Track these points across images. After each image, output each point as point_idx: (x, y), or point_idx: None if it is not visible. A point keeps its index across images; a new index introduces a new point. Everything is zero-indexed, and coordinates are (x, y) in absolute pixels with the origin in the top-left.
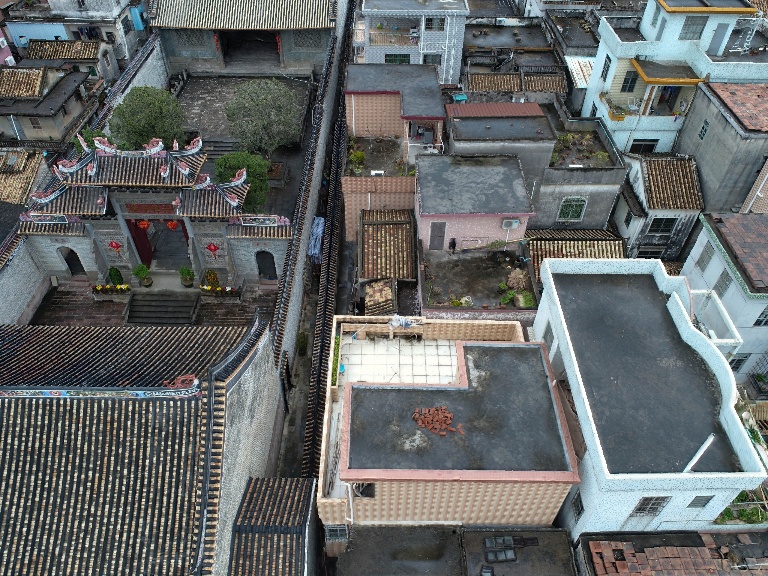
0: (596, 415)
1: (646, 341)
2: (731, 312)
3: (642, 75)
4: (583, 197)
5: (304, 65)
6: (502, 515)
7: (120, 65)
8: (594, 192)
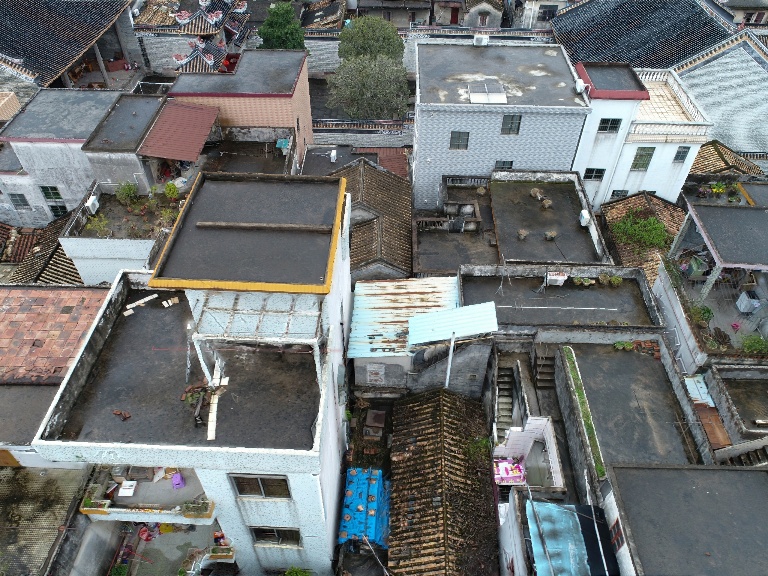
0: None
1: None
2: None
3: None
4: None
5: None
6: None
7: None
8: None
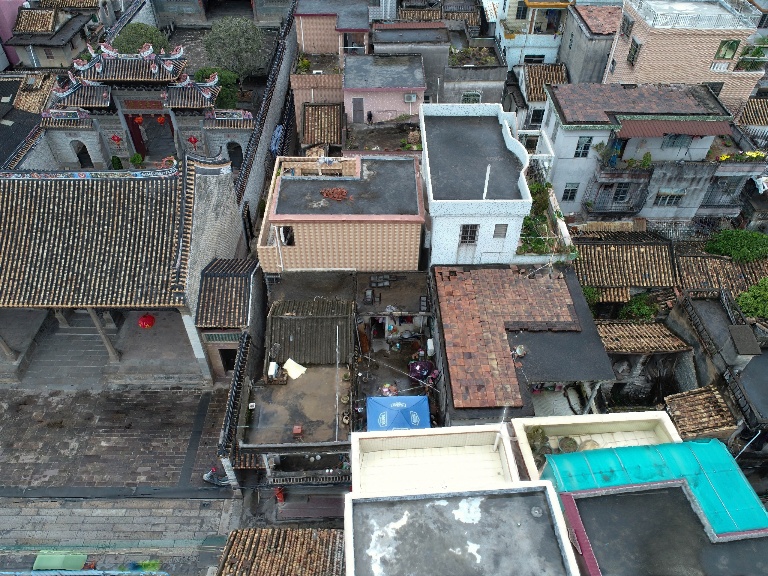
0: (438, 183)
1: (482, 149)
2: (558, 147)
3: (525, 1)
4: (477, 92)
5: (274, 19)
6: (382, 261)
7: (117, 17)
8: (485, 88)
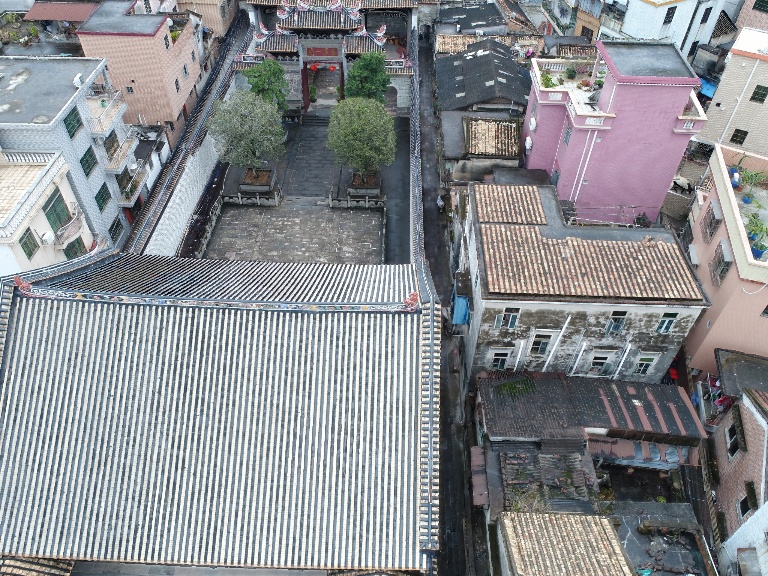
0: None
1: None
2: None
3: None
4: None
5: None
6: None
7: None
8: None
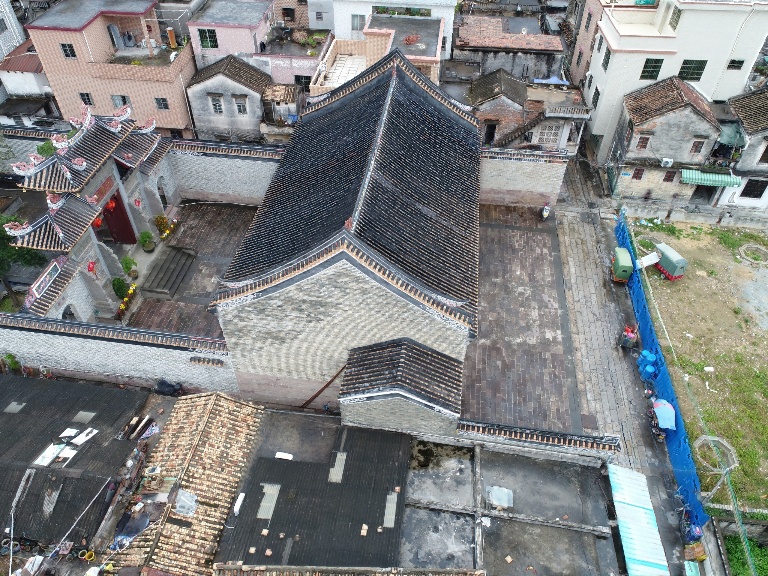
0: None
1: None
2: None
3: None
4: None
5: None
6: None
7: None
8: None
